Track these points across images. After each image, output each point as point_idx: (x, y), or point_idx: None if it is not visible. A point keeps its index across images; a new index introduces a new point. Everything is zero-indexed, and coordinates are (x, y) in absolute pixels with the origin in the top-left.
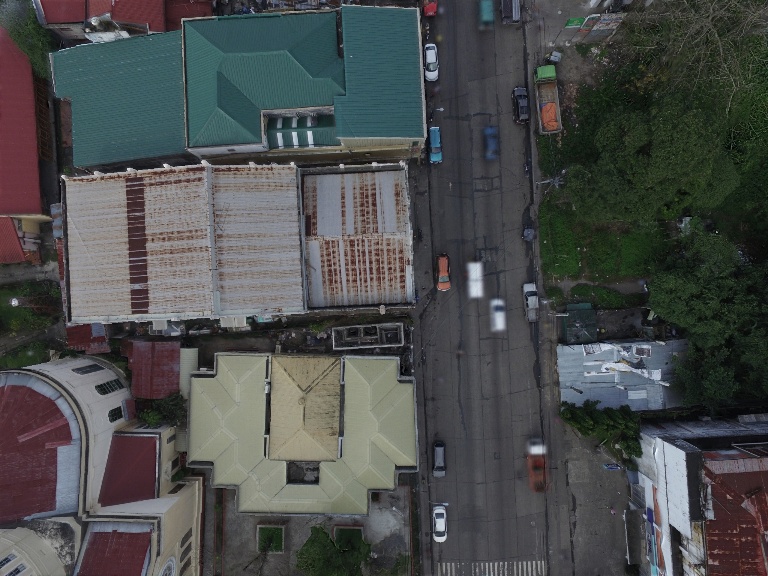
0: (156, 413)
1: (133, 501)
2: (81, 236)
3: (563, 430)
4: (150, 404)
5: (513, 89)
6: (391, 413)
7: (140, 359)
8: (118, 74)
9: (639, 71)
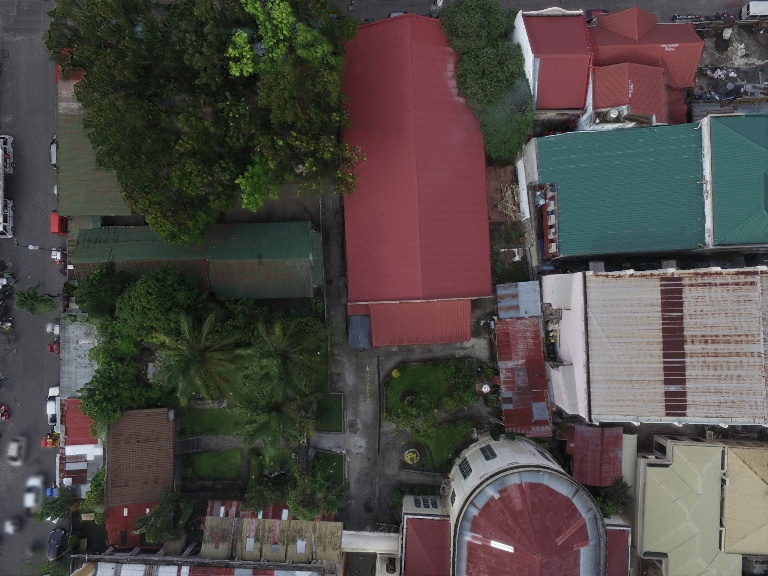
0: (613, 502)
1: None
2: (604, 333)
3: None
4: None
5: None
6: None
7: (585, 444)
8: (616, 164)
9: None
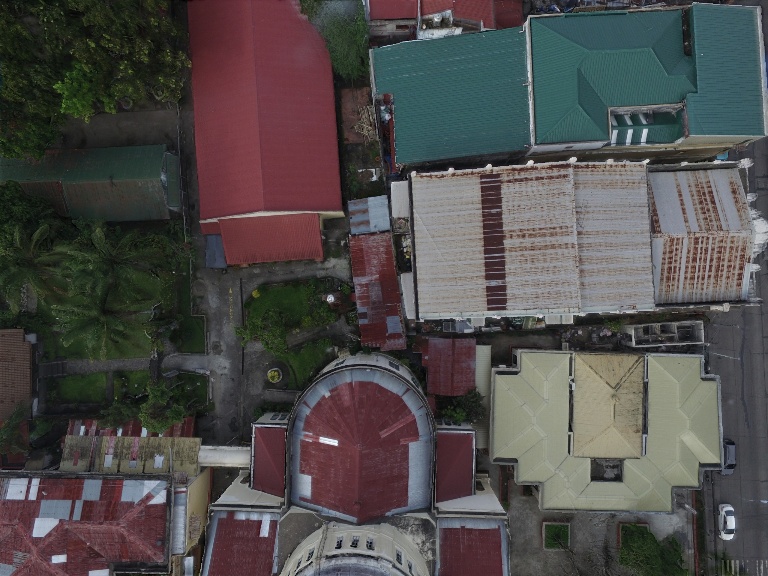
0: (462, 410)
1: (457, 497)
2: (430, 232)
3: None
4: None
5: None
6: (699, 411)
7: (438, 356)
8: (448, 71)
9: None
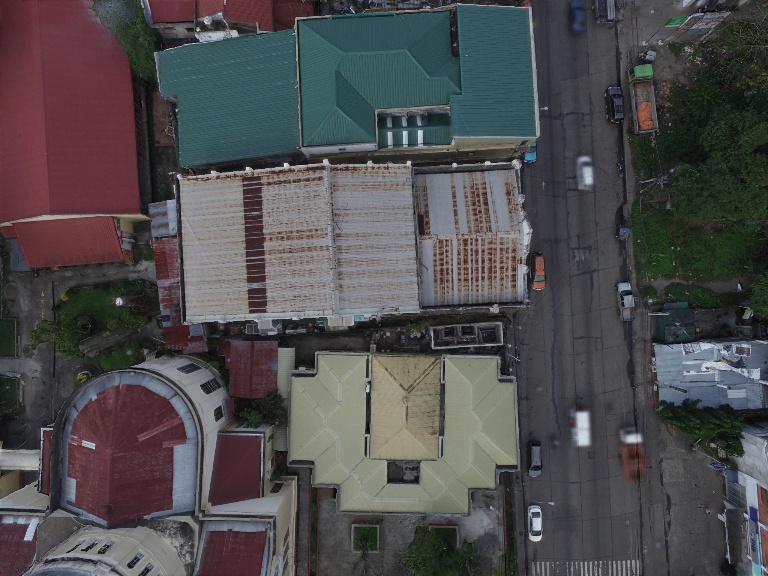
0: (257, 412)
1: (240, 500)
2: (196, 235)
3: (657, 429)
4: (244, 403)
5: (606, 88)
6: (493, 412)
7: (238, 358)
8: (226, 73)
9: (751, 70)
